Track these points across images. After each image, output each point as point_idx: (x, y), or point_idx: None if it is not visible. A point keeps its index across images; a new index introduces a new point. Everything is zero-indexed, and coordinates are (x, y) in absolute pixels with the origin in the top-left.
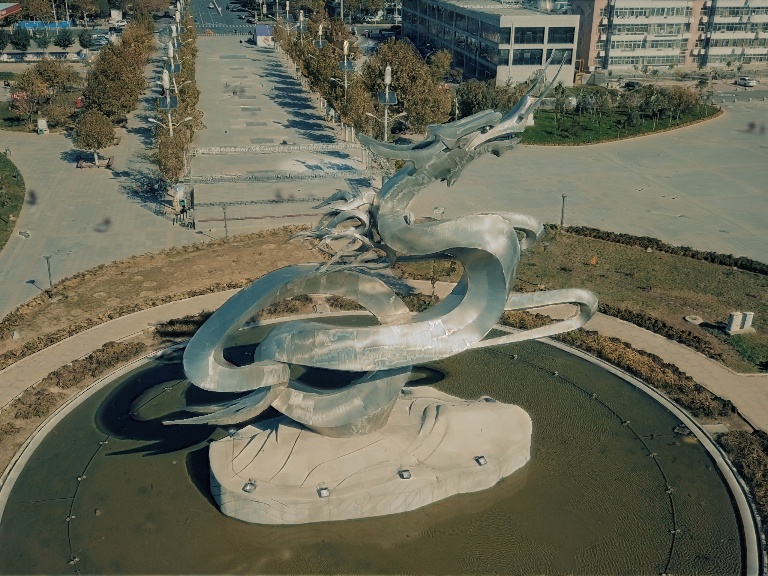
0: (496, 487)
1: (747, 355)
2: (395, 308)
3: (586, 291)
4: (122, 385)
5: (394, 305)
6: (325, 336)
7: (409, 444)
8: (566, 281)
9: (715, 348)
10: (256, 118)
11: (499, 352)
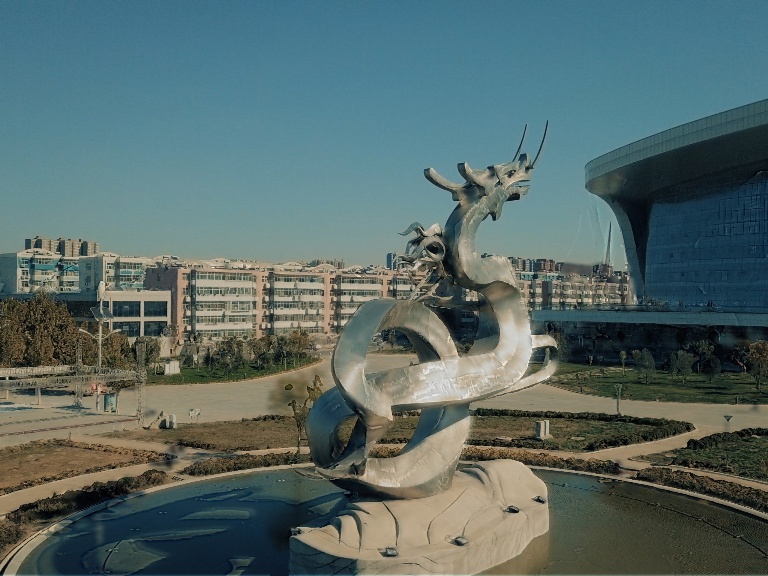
0: None
1: (570, 446)
2: (448, 350)
3: None
4: (42, 560)
5: (449, 346)
6: (417, 371)
7: (485, 492)
8: None
9: None
10: None
11: None
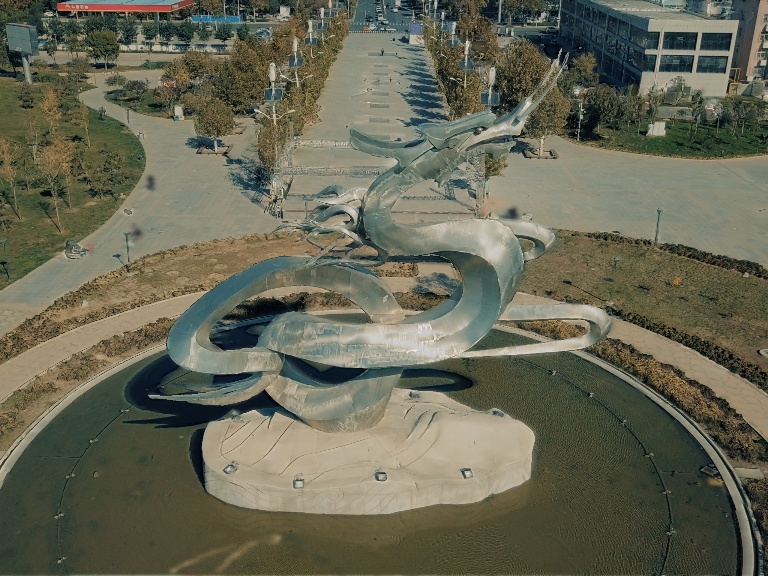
0: (484, 503)
1: None
2: (389, 308)
3: (596, 309)
4: (161, 359)
5: (387, 304)
6: (313, 329)
7: (395, 447)
8: (640, 300)
9: None
10: (381, 115)
11: (538, 366)
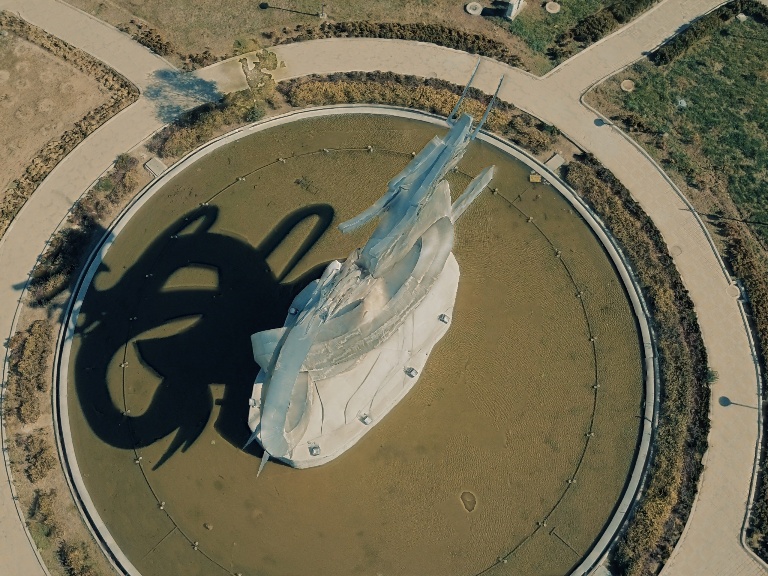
0: None
1: (535, 45)
2: None
3: (490, 170)
4: (79, 385)
5: (369, 283)
6: (335, 343)
7: (397, 343)
8: None
9: (509, 48)
10: None
11: (354, 149)
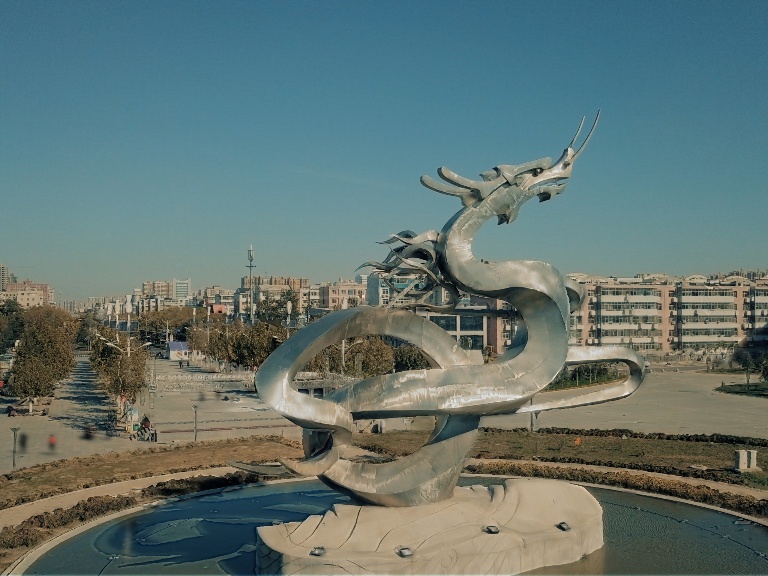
0: (581, 564)
1: (766, 482)
2: (457, 360)
3: None
4: (118, 525)
5: (456, 355)
6: (393, 379)
7: (484, 510)
8: (558, 455)
9: None
10: None
11: None
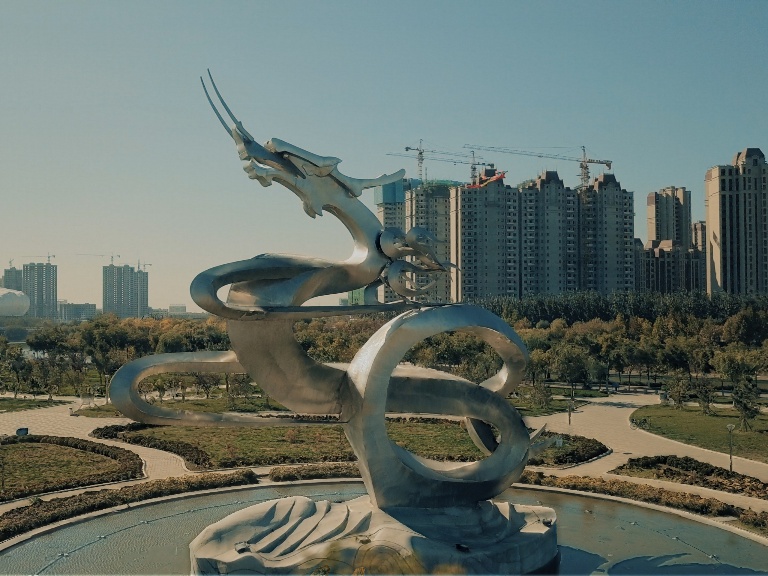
0: None
1: None
2: None
3: (134, 361)
4: None
5: None
6: None
7: None
8: None
9: None
10: None
11: None
